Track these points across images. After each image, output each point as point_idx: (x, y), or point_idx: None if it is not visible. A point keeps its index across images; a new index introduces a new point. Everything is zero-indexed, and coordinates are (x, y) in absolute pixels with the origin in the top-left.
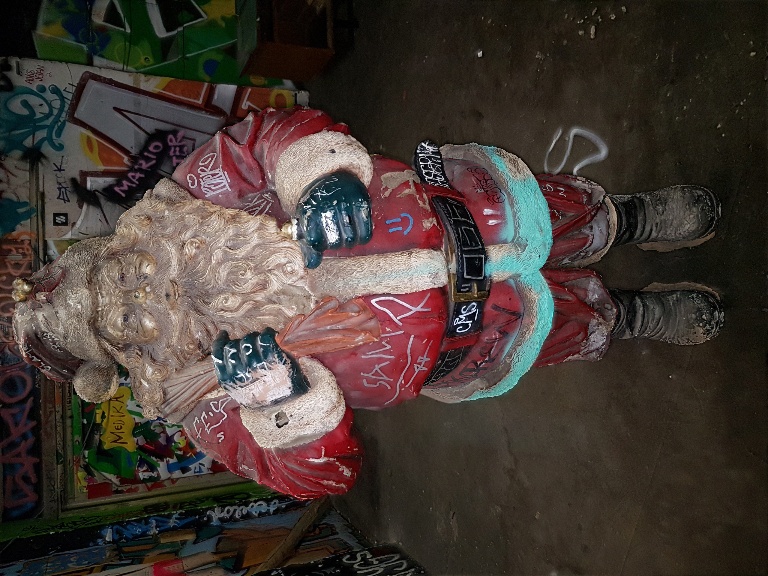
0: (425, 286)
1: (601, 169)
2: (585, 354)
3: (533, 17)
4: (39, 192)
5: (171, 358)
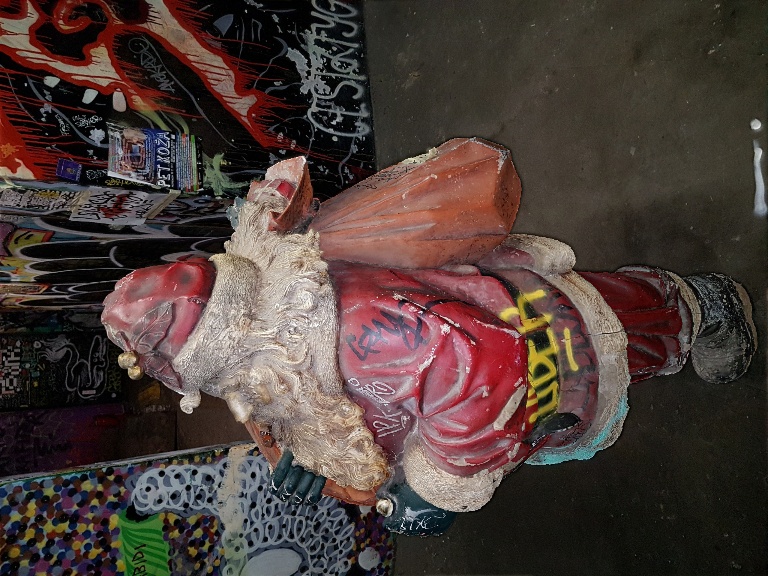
0: None
1: None
2: None
3: None
4: None
5: None
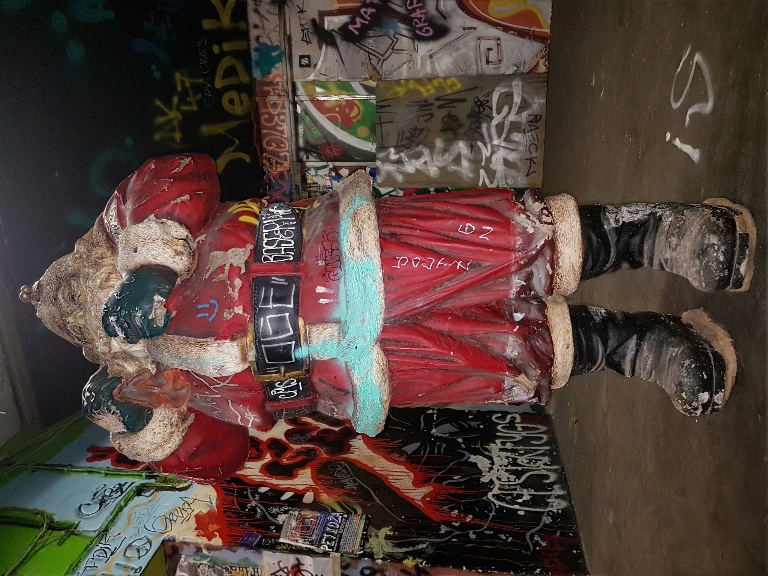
0: (213, 375)
1: (704, 126)
2: None
3: None
4: (286, 36)
5: None
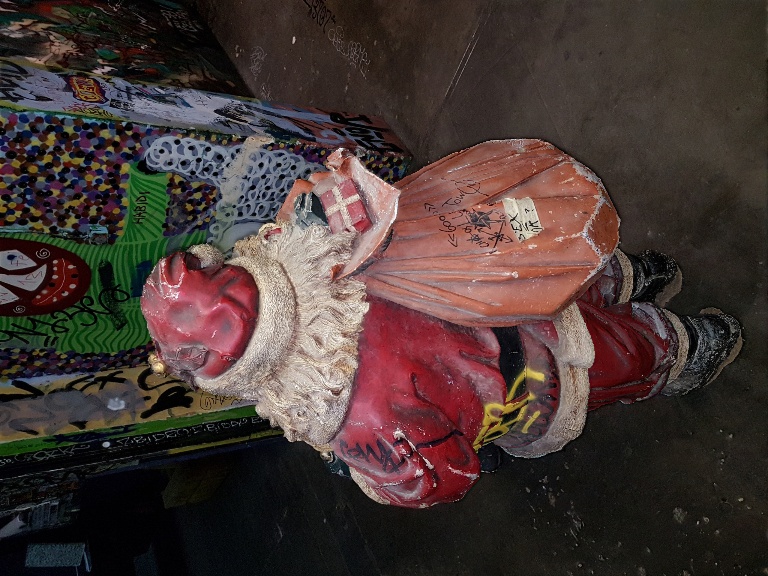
0: None
1: None
2: None
3: None
4: None
5: None
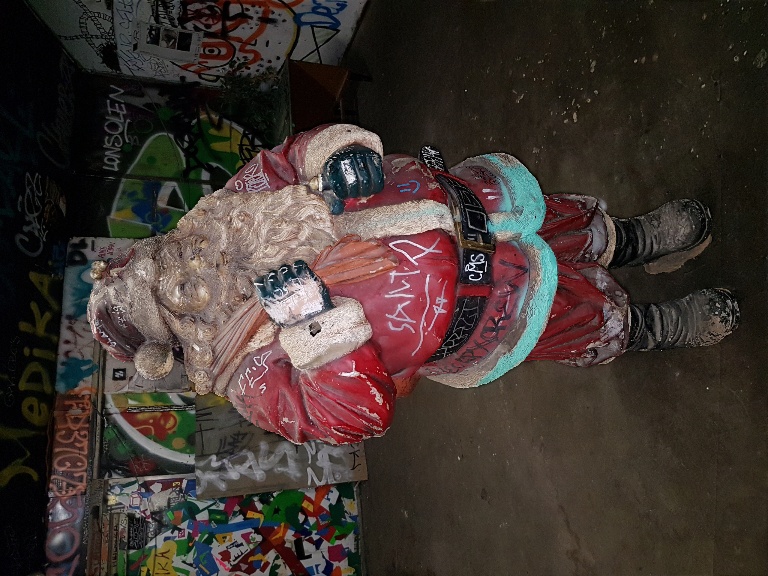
0: (433, 224)
1: None
2: (606, 342)
3: (525, 123)
4: (102, 350)
5: (220, 316)
